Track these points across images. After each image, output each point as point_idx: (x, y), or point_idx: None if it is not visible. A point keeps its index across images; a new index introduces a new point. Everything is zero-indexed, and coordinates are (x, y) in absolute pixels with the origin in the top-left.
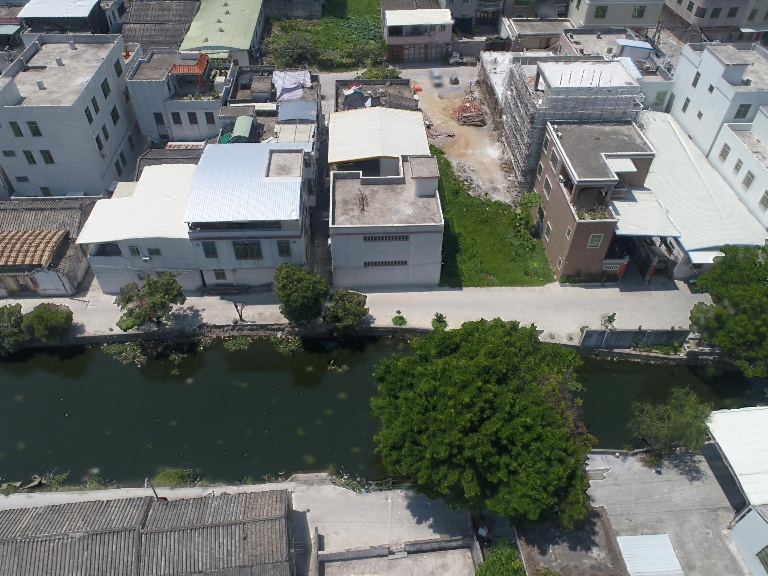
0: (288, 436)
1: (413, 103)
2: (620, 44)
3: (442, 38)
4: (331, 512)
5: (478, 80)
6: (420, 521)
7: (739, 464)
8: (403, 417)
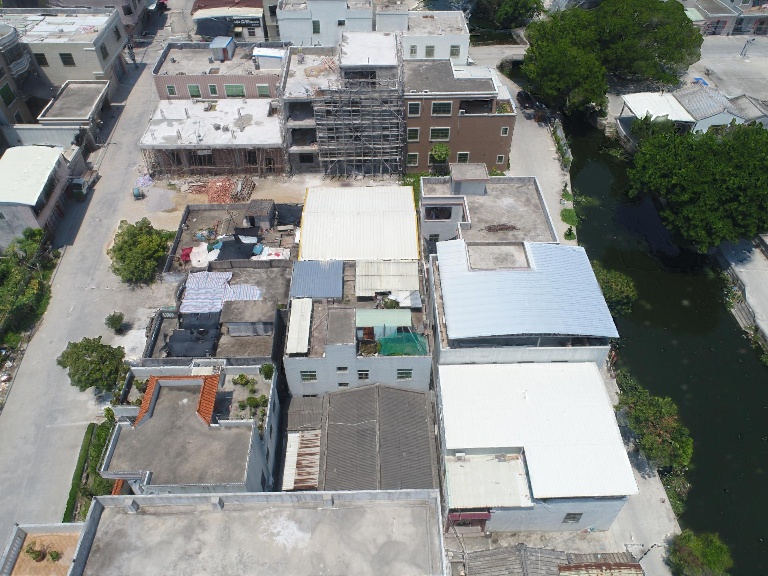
0: (710, 335)
1: (262, 201)
2: (224, 47)
3: (64, 174)
4: (767, 299)
5: (150, 174)
6: (748, 256)
7: (675, 118)
8: (762, 200)
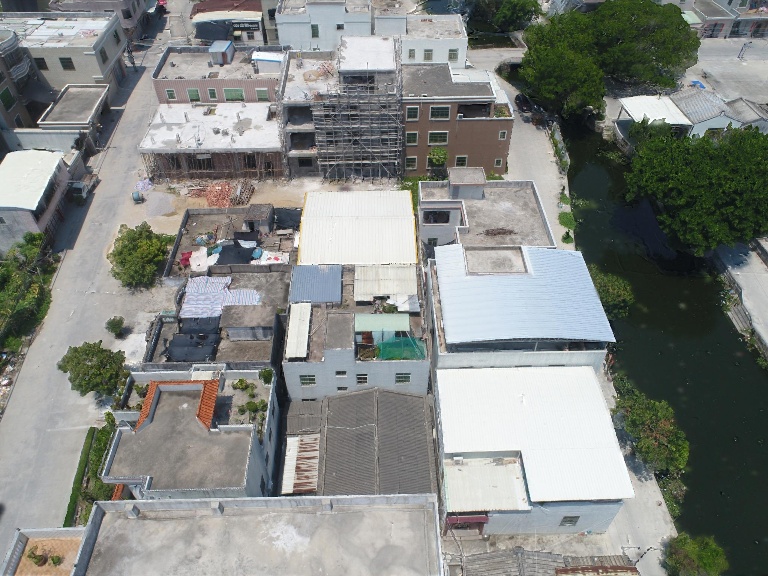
0: (707, 338)
1: (261, 206)
2: (223, 51)
3: (64, 178)
4: (764, 302)
5: (150, 178)
6: (745, 259)
7: (672, 121)
8: None
